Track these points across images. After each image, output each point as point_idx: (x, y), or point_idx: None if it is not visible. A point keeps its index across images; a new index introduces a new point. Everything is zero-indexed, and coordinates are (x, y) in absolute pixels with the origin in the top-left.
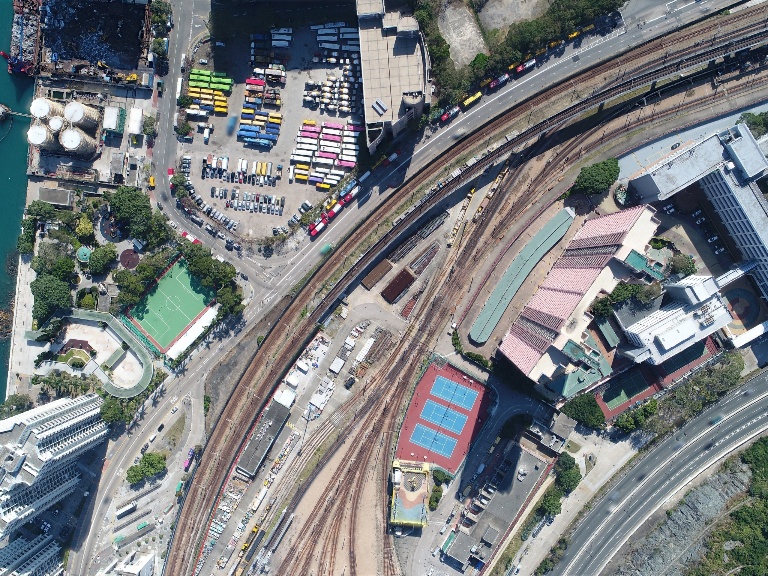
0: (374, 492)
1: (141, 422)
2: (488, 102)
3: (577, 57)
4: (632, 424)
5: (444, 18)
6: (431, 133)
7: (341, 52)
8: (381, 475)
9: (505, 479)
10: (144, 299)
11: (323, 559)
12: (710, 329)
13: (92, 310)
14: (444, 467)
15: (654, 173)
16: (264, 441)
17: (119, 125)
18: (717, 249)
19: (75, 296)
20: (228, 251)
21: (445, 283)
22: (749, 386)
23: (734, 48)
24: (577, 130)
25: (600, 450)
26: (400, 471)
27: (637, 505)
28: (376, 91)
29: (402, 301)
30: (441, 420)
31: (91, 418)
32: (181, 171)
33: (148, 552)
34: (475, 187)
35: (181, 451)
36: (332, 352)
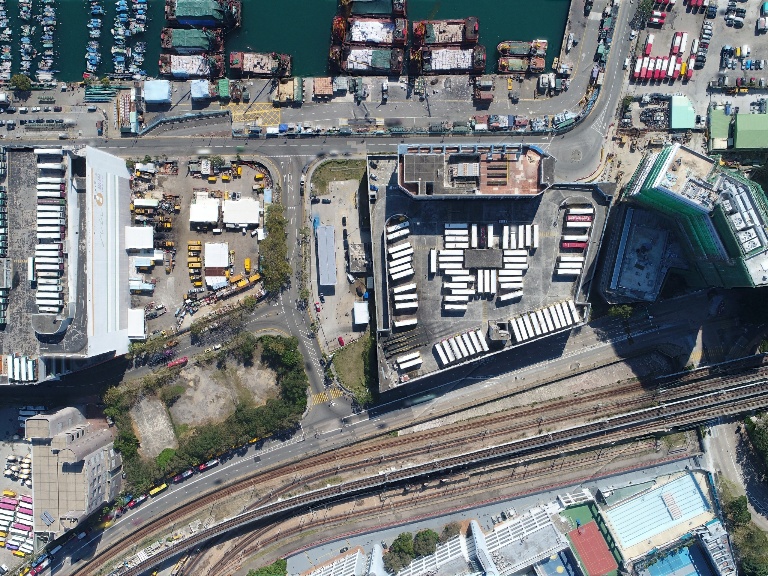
0: None
1: None
2: (175, 490)
3: (258, 458)
4: None
5: (139, 408)
6: (121, 513)
7: None
8: None
9: None
10: None
11: None
12: None
13: None
14: None
15: None
16: None
17: None
18: None
19: None
20: None
21: None
22: None
23: (392, 477)
24: (255, 525)
25: None
26: None
27: None
28: (45, 502)
29: None
30: None
31: None
32: None
33: None
34: (158, 569)
35: None
36: None
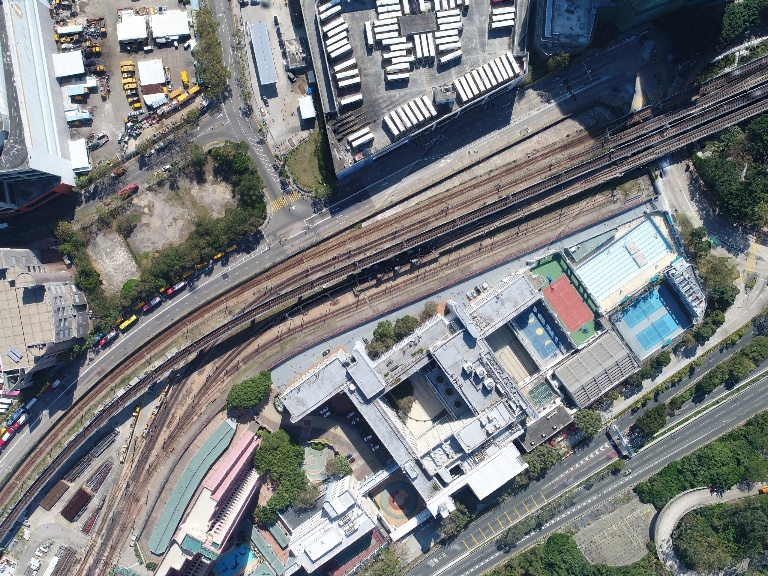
0: None
1: None
2: (146, 322)
3: (226, 275)
4: None
5: (96, 245)
6: (94, 355)
7: None
8: None
9: None
10: None
11: None
12: (355, 535)
13: None
14: None
15: (284, 398)
16: None
17: None
18: (373, 446)
19: None
20: None
21: (122, 498)
22: (414, 572)
23: (362, 265)
24: (233, 343)
25: None
26: None
27: None
28: (10, 339)
29: (82, 518)
30: None
31: None
32: None
33: None
34: (141, 405)
35: None
36: (19, 573)
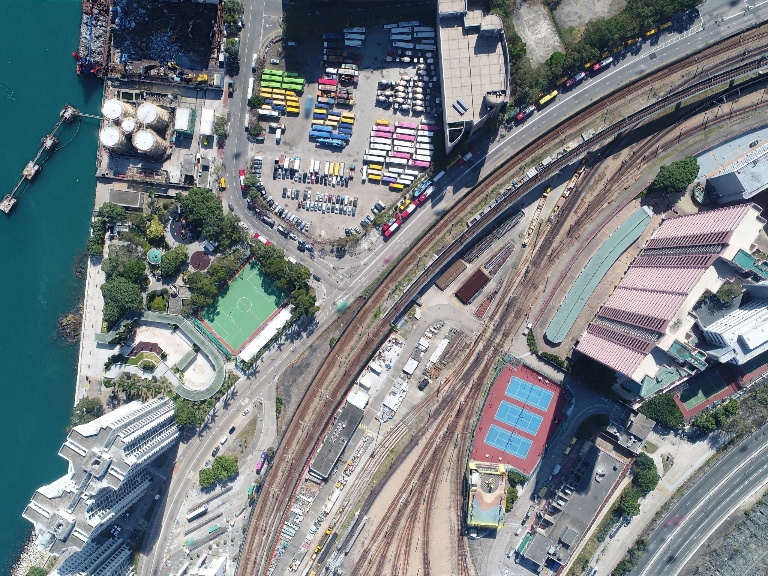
0: (448, 494)
1: (212, 425)
2: (563, 101)
3: (654, 55)
4: (713, 424)
5: (519, 16)
6: (506, 132)
7: (415, 51)
8: (455, 477)
9: (583, 480)
10: (215, 301)
11: (396, 561)
12: None
13: (163, 312)
14: (519, 468)
15: (739, 171)
16: (337, 443)
17: (190, 126)
18: None
19: (145, 298)
20: (300, 252)
21: (520, 283)
22: None
23: None
24: (654, 128)
25: (678, 450)
26: (477, 473)
27: (715, 505)
28: (457, 90)
29: (476, 301)
30: (516, 421)
31: (165, 421)
32: (253, 172)
33: (219, 555)
34: (551, 186)
35: (252, 454)
36: (405, 353)
